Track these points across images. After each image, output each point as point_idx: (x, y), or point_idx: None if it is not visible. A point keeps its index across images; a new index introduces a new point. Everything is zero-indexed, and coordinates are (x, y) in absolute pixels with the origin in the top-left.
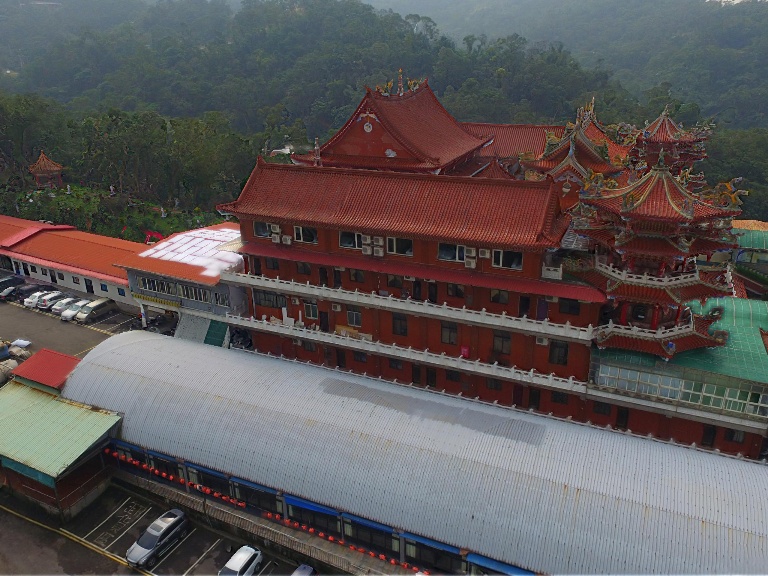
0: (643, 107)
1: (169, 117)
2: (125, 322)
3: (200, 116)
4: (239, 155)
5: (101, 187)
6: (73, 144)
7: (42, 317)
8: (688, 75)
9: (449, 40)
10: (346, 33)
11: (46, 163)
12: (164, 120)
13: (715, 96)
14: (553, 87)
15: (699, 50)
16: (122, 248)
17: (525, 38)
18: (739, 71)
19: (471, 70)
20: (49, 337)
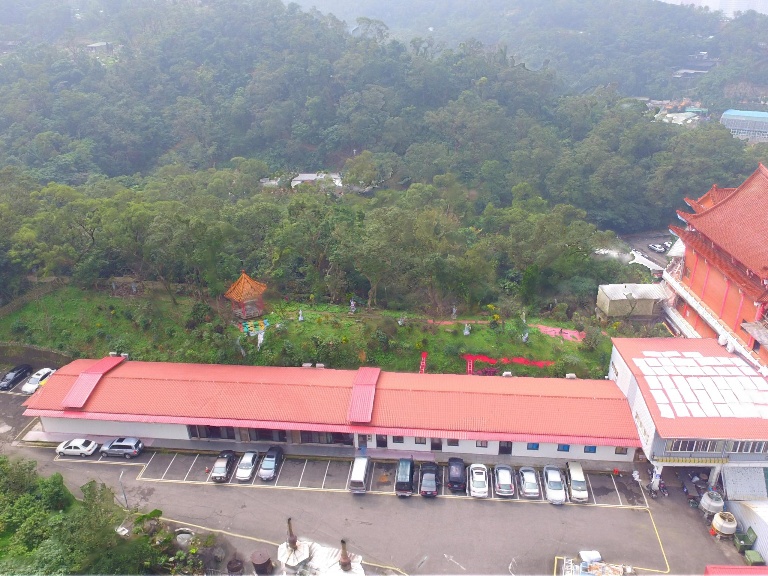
0: (633, 113)
1: (171, 166)
2: (617, 486)
3: (224, 164)
4: (445, 234)
5: (316, 301)
6: (235, 248)
7: (523, 507)
8: (547, 56)
9: (402, 44)
10: (302, 41)
11: (252, 285)
12: (413, 216)
13: (576, 76)
14: (531, 93)
15: (550, 32)
16: (521, 394)
17: (481, 42)
18: (588, 52)
19: (447, 79)
20: (589, 535)
